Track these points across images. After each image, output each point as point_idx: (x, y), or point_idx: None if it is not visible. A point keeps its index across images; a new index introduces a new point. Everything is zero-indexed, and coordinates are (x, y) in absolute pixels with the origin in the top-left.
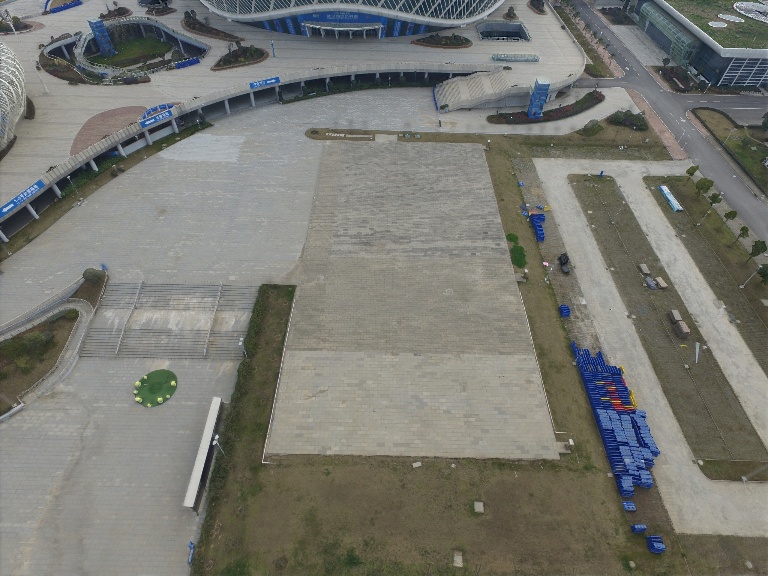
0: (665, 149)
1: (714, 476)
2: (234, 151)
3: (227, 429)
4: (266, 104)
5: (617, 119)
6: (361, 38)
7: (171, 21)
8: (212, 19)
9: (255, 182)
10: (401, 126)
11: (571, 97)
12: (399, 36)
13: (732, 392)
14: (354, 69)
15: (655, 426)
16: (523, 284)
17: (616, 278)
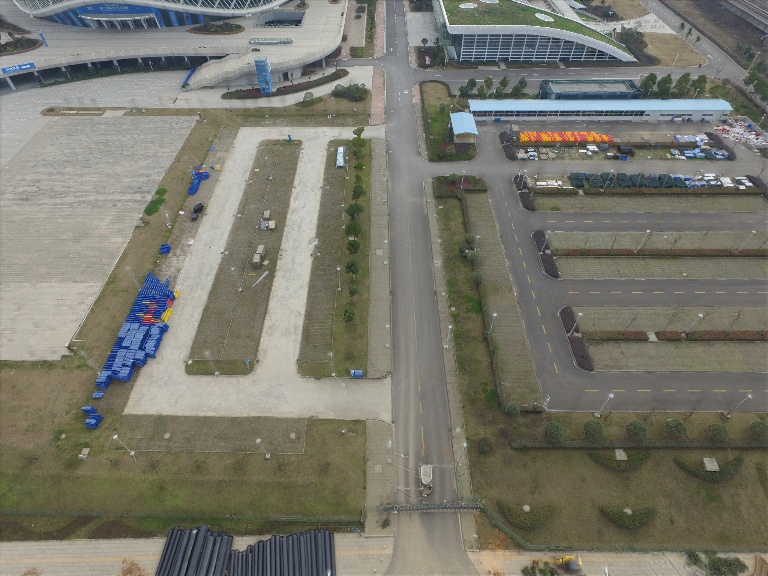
0: (368, 116)
1: (193, 372)
2: None
3: None
4: (28, 88)
5: (338, 92)
6: (142, 28)
7: None
8: (17, 16)
9: None
10: (137, 103)
11: (317, 75)
12: (180, 26)
13: (265, 309)
14: (113, 55)
15: (173, 336)
16: (140, 228)
17: (236, 222)
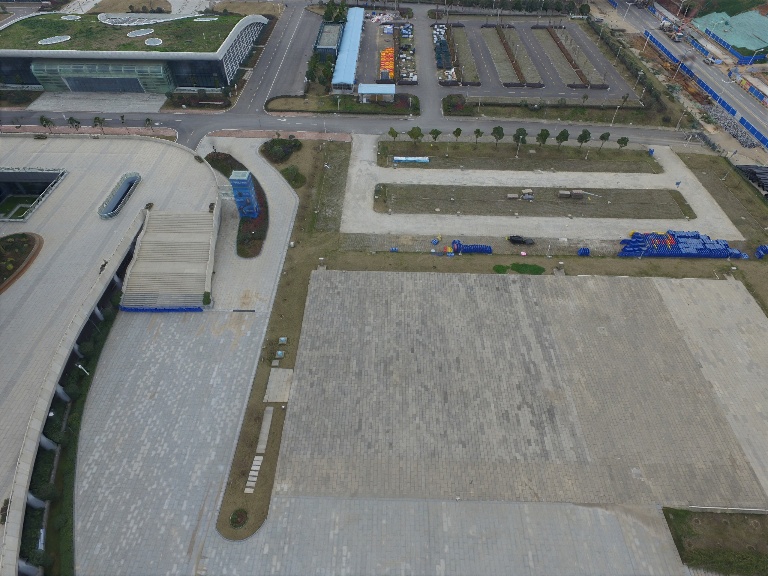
0: (334, 142)
1: (694, 215)
2: None
3: None
4: None
5: (282, 154)
6: None
7: None
8: None
9: None
10: (242, 363)
11: None
12: None
13: (621, 189)
14: (36, 426)
15: None
16: (567, 272)
17: (528, 214)
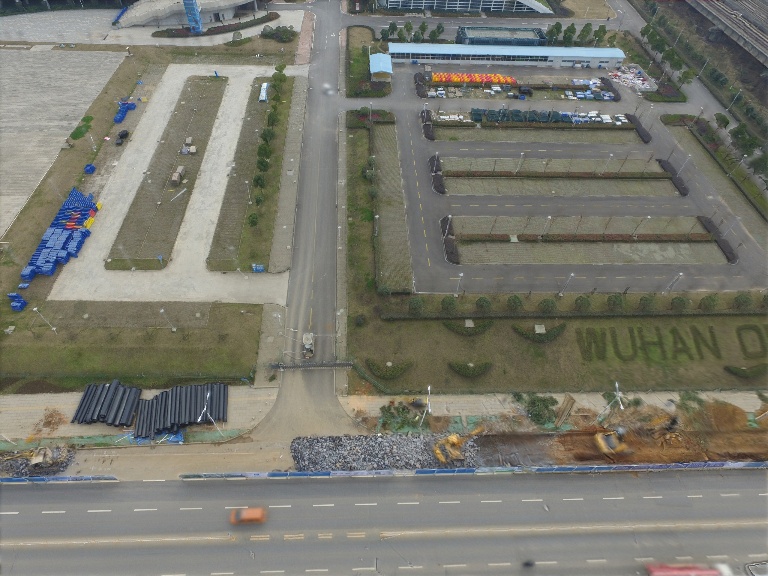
0: (294, 57)
1: (112, 268)
2: None
3: None
4: None
5: (266, 33)
6: None
7: None
8: None
9: None
10: (66, 39)
11: (249, 17)
12: None
13: (181, 219)
14: None
15: (95, 240)
16: (65, 150)
17: (159, 147)
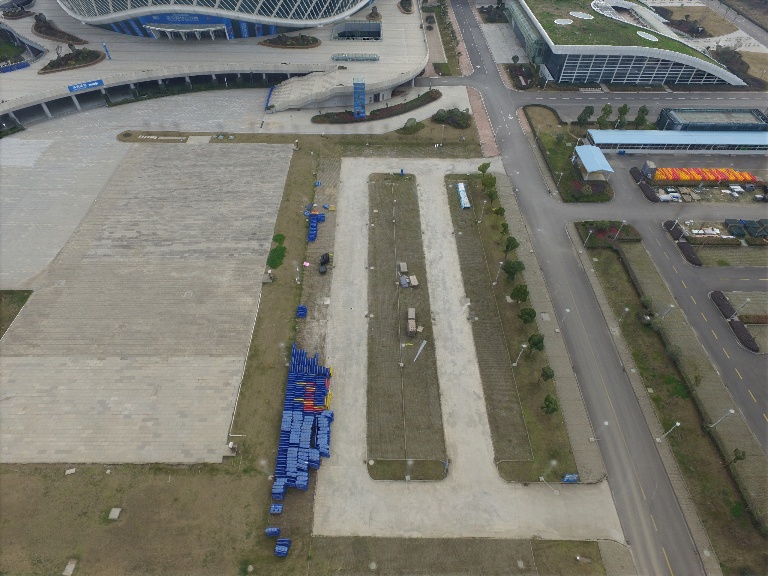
0: (479, 147)
1: (379, 476)
2: (35, 155)
3: None
4: (94, 107)
5: (440, 117)
6: (209, 39)
7: (23, 25)
8: (66, 22)
9: (41, 186)
10: (221, 127)
11: (408, 96)
12: (249, 37)
13: (437, 390)
14: (186, 71)
15: (342, 426)
16: (268, 285)
17: (371, 277)
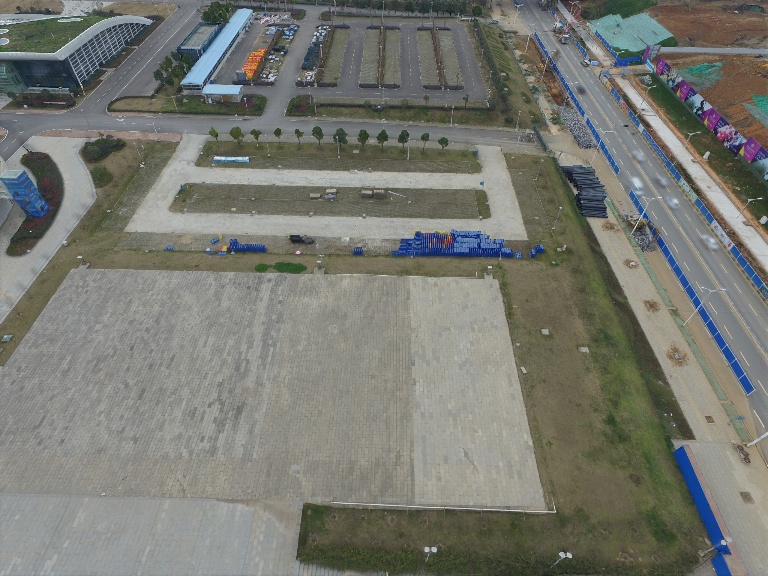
0: (161, 142)
1: (489, 215)
2: None
3: (526, 567)
4: None
5: (97, 154)
6: None
7: None
8: None
9: None
10: None
11: None
12: None
13: (428, 189)
14: None
15: (459, 229)
16: (328, 270)
17: (322, 214)
